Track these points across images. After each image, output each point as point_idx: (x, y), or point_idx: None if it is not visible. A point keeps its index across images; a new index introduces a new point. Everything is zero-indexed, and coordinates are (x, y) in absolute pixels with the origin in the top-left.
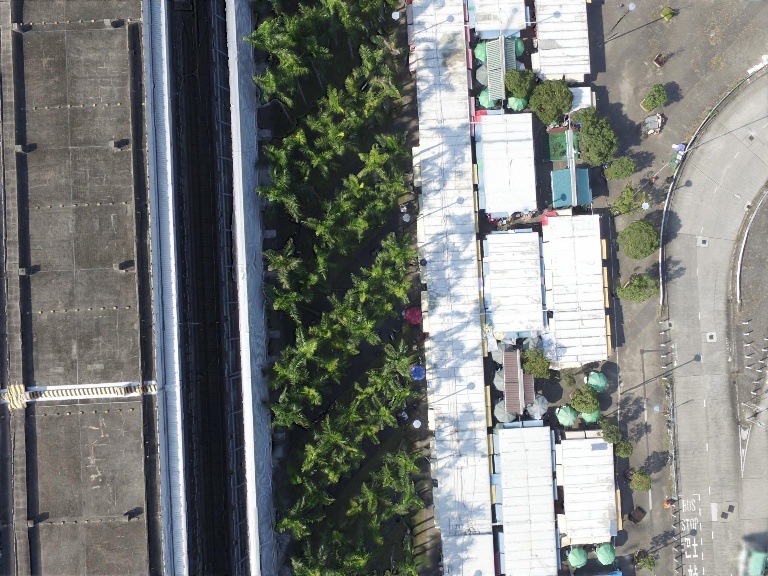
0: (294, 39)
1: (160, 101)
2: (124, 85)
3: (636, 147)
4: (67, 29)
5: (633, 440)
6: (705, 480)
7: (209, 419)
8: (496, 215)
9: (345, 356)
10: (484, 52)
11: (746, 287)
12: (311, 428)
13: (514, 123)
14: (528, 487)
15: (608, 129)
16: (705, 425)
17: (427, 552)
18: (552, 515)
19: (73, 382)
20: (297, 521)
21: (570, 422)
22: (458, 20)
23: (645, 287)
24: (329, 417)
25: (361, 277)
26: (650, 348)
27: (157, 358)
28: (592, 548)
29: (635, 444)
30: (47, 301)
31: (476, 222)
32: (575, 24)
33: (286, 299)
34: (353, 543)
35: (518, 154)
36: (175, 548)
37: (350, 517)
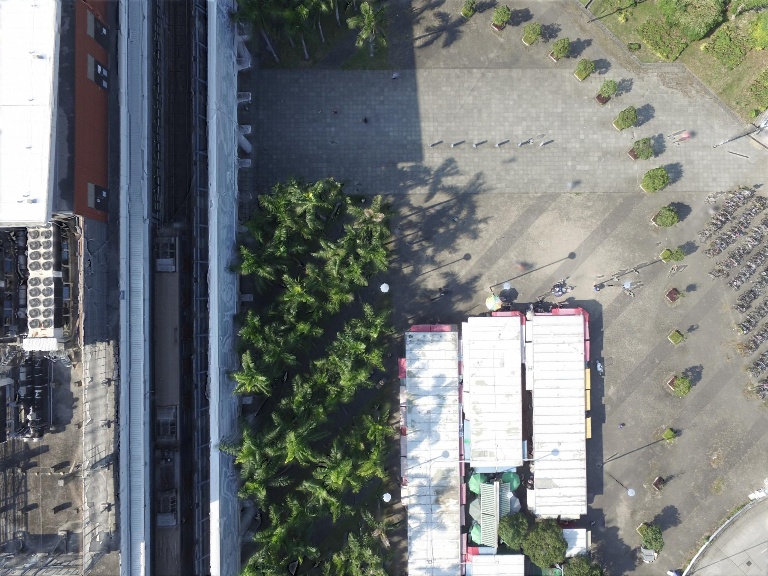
0: None
1: None
2: None
3: (630, 573)
4: None
5: None
6: None
7: None
8: None
9: None
10: (478, 489)
11: None
12: None
13: (506, 565)
14: None
15: None
16: None
17: None
18: None
19: None
20: None
21: None
22: (453, 456)
23: None
24: None
25: None
26: None
27: None
28: None
29: None
30: None
31: None
32: (573, 462)
33: None
34: None
35: None
36: None
37: None
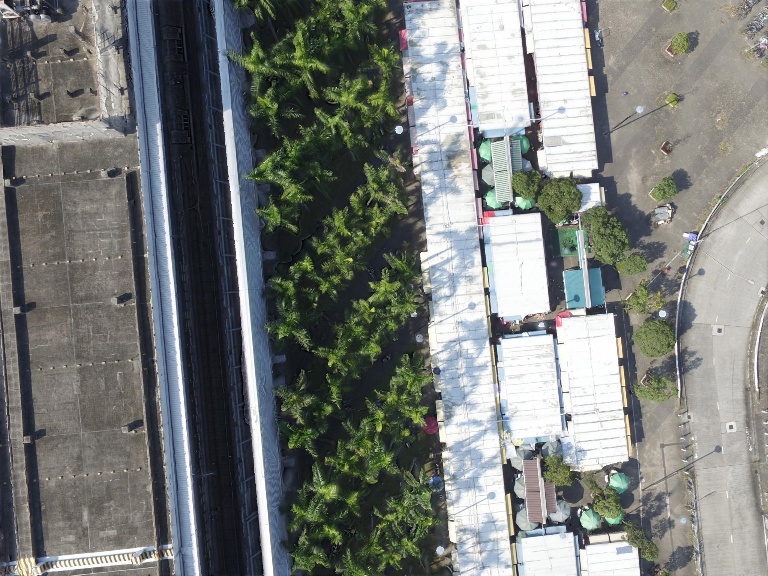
0: (297, 164)
1: (163, 251)
2: (124, 237)
3: (647, 238)
4: (62, 181)
5: (657, 536)
6: (731, 573)
7: (226, 556)
8: (509, 318)
9: (363, 485)
10: (489, 152)
11: (764, 374)
12: (331, 561)
13: (523, 224)
14: None
15: (619, 229)
16: (729, 517)
17: None
18: None
19: (85, 550)
20: None
21: (593, 527)
22: (461, 120)
23: (664, 388)
24: (350, 552)
25: (376, 402)
26: (670, 442)
27: (172, 523)
28: None
29: (659, 540)
30: (54, 467)
31: (489, 327)
32: (580, 119)
33: (301, 436)
34: None
35: (528, 255)
36: None
37: None
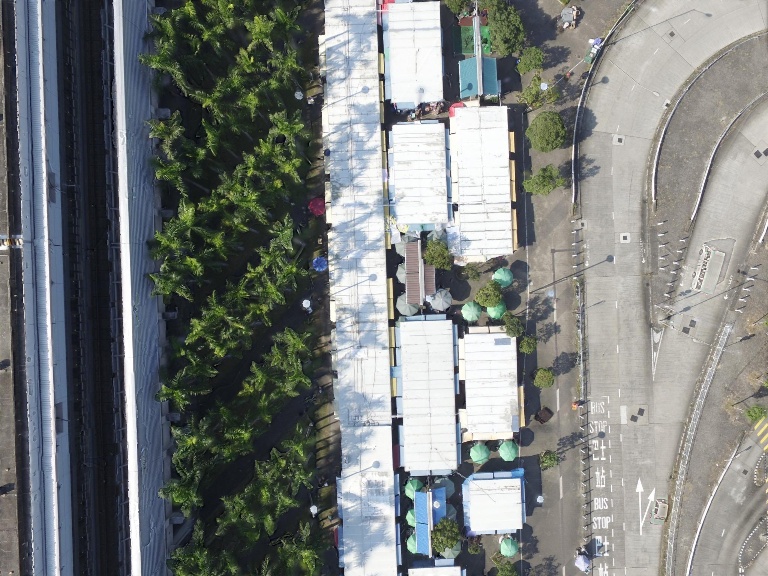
0: None
1: None
2: None
3: (551, 42)
4: None
5: (542, 340)
6: (615, 382)
7: (99, 295)
8: (402, 105)
9: (235, 234)
10: None
11: (662, 187)
12: (199, 305)
13: (422, 11)
14: (429, 380)
15: (515, 14)
16: (616, 327)
17: (330, 447)
18: (453, 409)
19: None
20: (178, 391)
21: (473, 316)
22: None
23: (550, 178)
24: (215, 292)
25: None
26: (561, 247)
27: (23, 210)
28: (497, 447)
29: (544, 344)
30: None
31: (381, 112)
32: None
33: (170, 169)
34: (239, 419)
35: (425, 43)
36: (42, 401)
37: (240, 397)
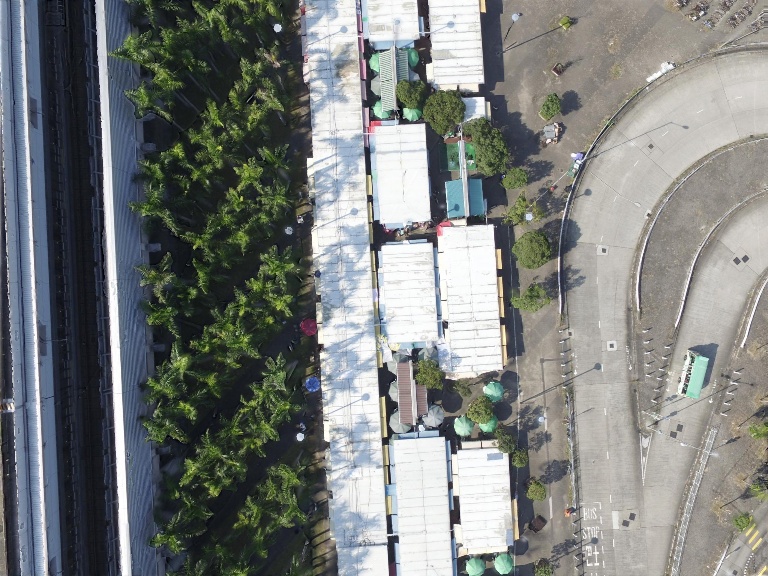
0: (170, 53)
1: (20, 118)
2: None
3: (535, 156)
4: None
5: (533, 449)
6: (606, 488)
7: (91, 434)
8: (390, 226)
9: (227, 370)
10: (378, 63)
11: (646, 295)
12: (193, 442)
13: (408, 134)
14: (423, 497)
15: (499, 139)
16: (606, 433)
17: (326, 563)
18: (448, 525)
19: None
20: (173, 536)
21: (466, 432)
22: (351, 31)
23: (537, 297)
24: (208, 431)
25: (243, 290)
26: (550, 357)
27: (15, 376)
28: (492, 557)
29: (535, 453)
30: None
31: (370, 233)
32: (469, 34)
33: (161, 314)
34: (235, 557)
35: (412, 165)
36: (36, 566)
37: (236, 530)
